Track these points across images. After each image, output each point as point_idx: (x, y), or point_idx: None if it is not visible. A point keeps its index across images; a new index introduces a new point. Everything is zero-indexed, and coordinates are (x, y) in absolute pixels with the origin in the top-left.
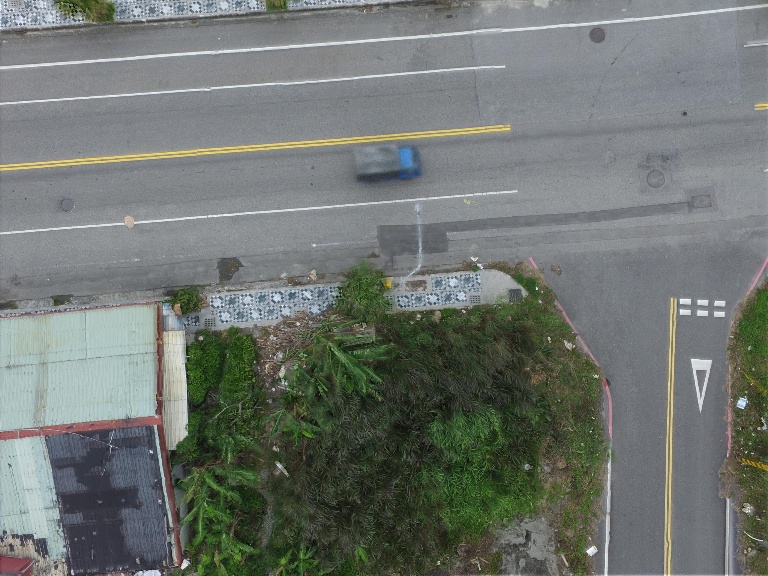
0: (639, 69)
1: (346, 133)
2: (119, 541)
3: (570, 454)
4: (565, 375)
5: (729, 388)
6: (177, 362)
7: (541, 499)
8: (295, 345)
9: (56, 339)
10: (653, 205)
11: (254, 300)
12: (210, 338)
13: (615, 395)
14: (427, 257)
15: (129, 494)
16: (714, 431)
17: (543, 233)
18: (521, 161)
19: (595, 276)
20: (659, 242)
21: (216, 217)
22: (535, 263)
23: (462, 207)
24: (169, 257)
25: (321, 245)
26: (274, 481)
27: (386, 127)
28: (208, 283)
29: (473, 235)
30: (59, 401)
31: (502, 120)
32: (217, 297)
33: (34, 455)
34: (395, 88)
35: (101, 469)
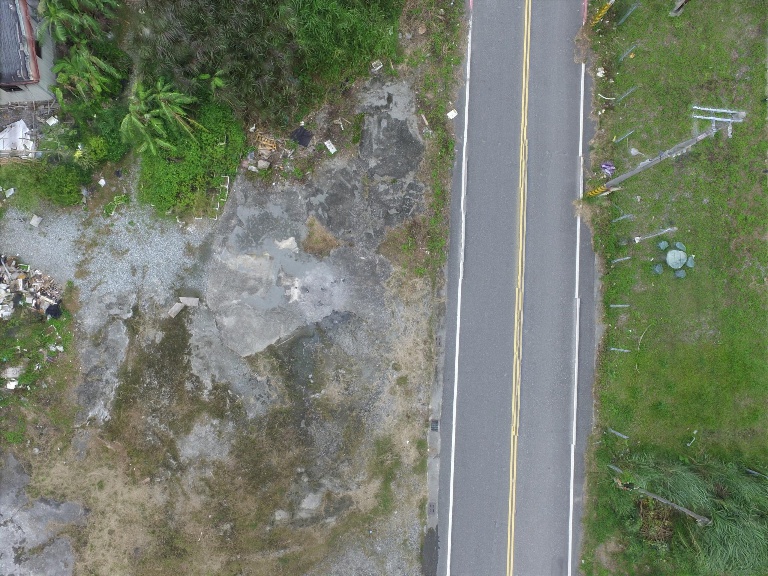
0: None
1: None
2: None
3: (429, 17)
4: None
5: None
6: None
7: (402, 63)
8: None
9: None
10: None
11: None
12: None
13: None
14: None
15: None
16: (571, 2)
17: None
18: None
19: None
20: None
21: None
22: None
23: None
24: None
25: None
26: None
27: None
28: None
29: None
30: None
31: None
32: None
33: None
34: None
35: None
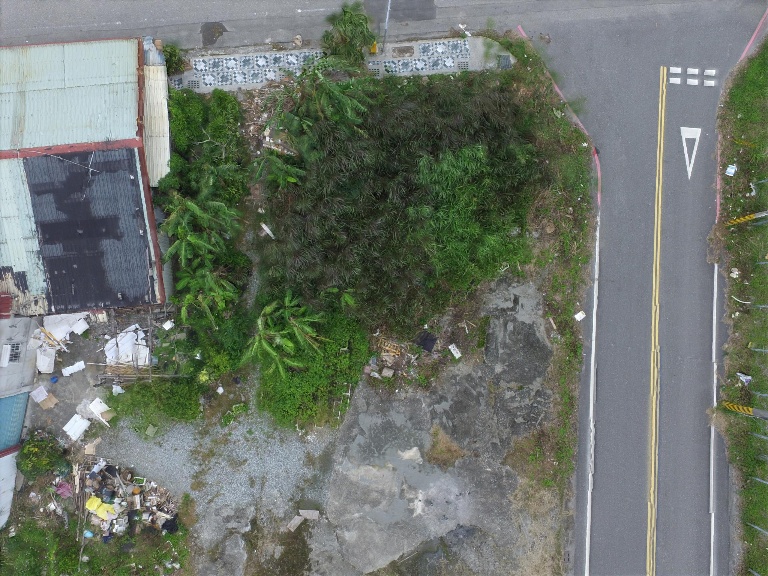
0: None
1: None
2: (100, 275)
3: (558, 217)
4: (554, 141)
5: (718, 156)
6: (158, 98)
7: (529, 263)
8: (280, 104)
9: (34, 70)
10: None
11: (238, 64)
12: (193, 94)
13: (604, 163)
14: (414, 24)
15: (110, 223)
16: (703, 198)
17: (532, 1)
18: None
19: (584, 44)
20: (649, 11)
21: None
22: (524, 31)
23: None
24: (151, 20)
25: (307, 11)
26: (259, 242)
27: None
28: (191, 47)
29: (461, 2)
30: (37, 127)
31: None
32: (200, 60)
33: (12, 179)
34: None
35: (81, 195)
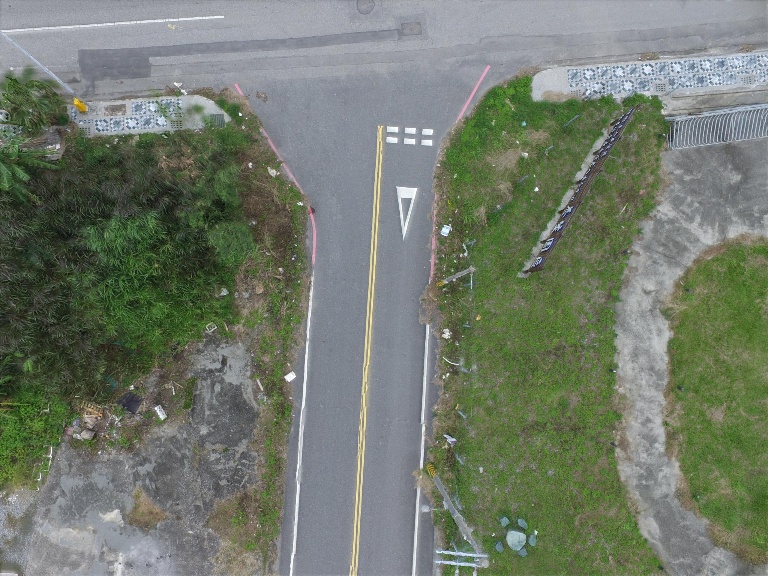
0: None
1: None
2: None
3: (266, 278)
4: (266, 201)
5: (434, 216)
6: None
7: (238, 324)
8: None
9: None
10: (362, 32)
11: None
12: None
13: (319, 223)
14: (130, 82)
15: None
16: (417, 258)
17: (249, 59)
18: None
19: (301, 103)
20: (367, 70)
21: None
22: (241, 89)
23: (166, 32)
24: None
25: (19, 68)
26: None
27: None
28: None
29: (177, 60)
30: None
31: None
32: None
33: None
34: None
35: None
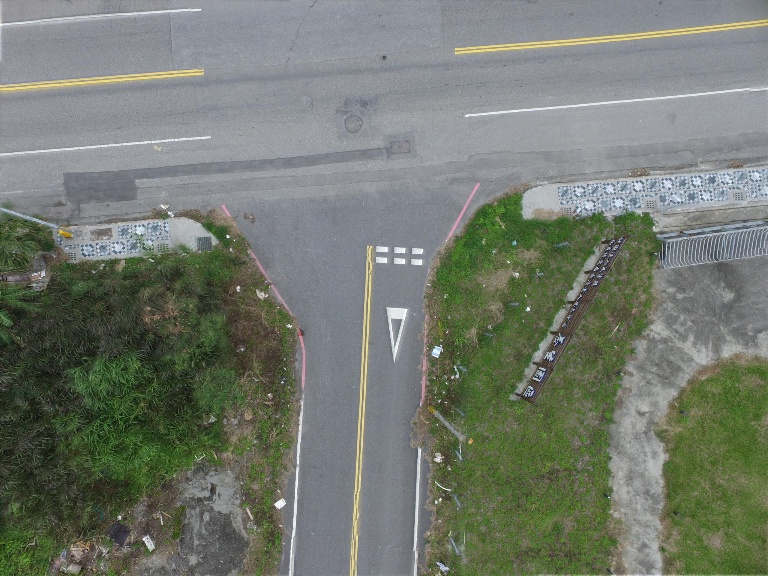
0: (340, 12)
1: (31, 77)
2: None
3: (255, 405)
4: (255, 325)
5: (425, 337)
6: None
7: (227, 451)
8: None
9: None
10: (350, 151)
11: None
12: None
13: (308, 345)
14: (116, 205)
15: None
16: (408, 380)
17: (236, 180)
18: (214, 106)
19: (289, 224)
20: (356, 189)
21: None
22: (228, 211)
23: (152, 153)
24: None
25: (4, 193)
26: None
27: (73, 71)
28: None
29: (163, 182)
30: None
31: (195, 64)
32: None
33: None
34: (84, 31)
35: None
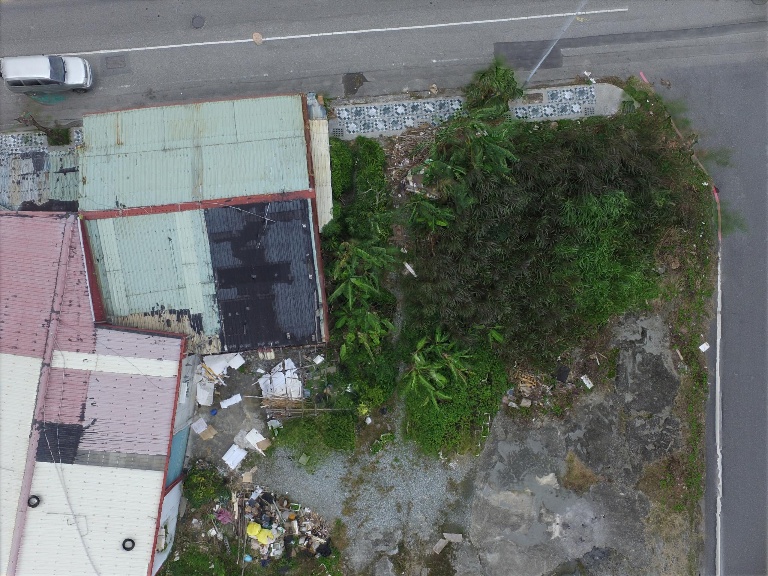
0: None
1: None
2: (271, 316)
3: (683, 254)
4: None
5: None
6: (321, 150)
7: (656, 298)
8: (421, 150)
9: (207, 126)
10: (757, 21)
11: (379, 112)
12: (341, 142)
13: (723, 202)
14: (542, 72)
15: (282, 268)
16: None
17: (653, 49)
18: None
19: (703, 89)
20: (763, 57)
21: (340, 34)
22: (645, 78)
23: (575, 24)
24: (296, 72)
25: (441, 61)
26: (403, 280)
27: None
28: (334, 97)
29: (586, 51)
30: (215, 180)
31: None
32: (343, 109)
33: (193, 229)
34: None
35: (256, 243)
